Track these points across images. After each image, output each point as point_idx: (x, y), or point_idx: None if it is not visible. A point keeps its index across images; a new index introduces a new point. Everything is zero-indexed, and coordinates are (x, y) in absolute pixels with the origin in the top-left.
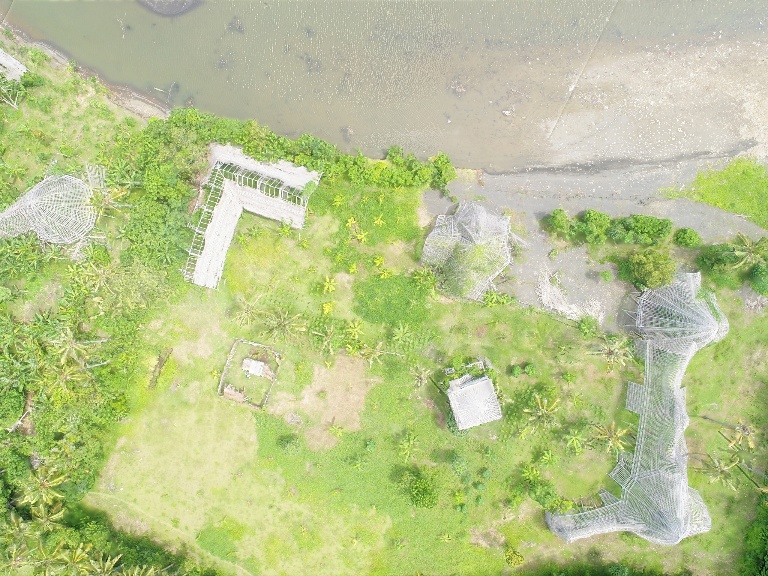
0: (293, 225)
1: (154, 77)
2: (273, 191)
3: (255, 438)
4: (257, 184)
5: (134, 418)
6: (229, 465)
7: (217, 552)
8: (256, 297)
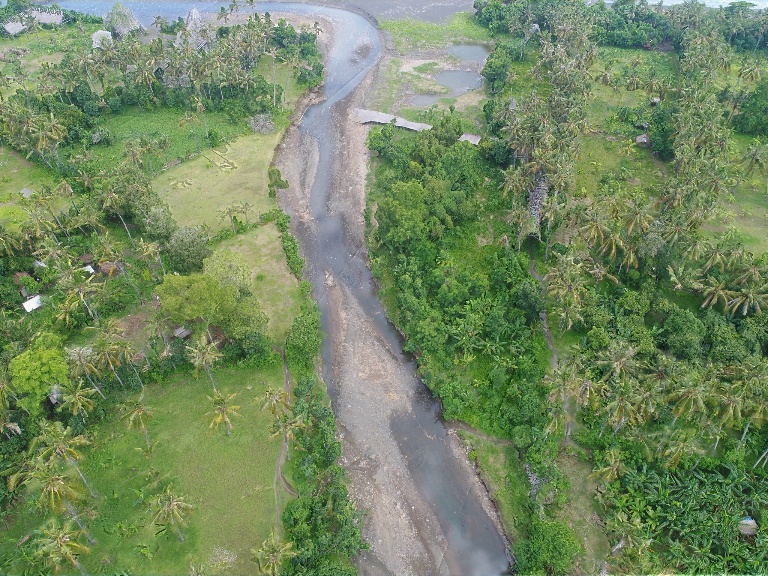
0: (56, 24)
1: None
2: (52, 12)
3: (1, 69)
4: (47, 11)
5: None
6: None
7: None
8: None
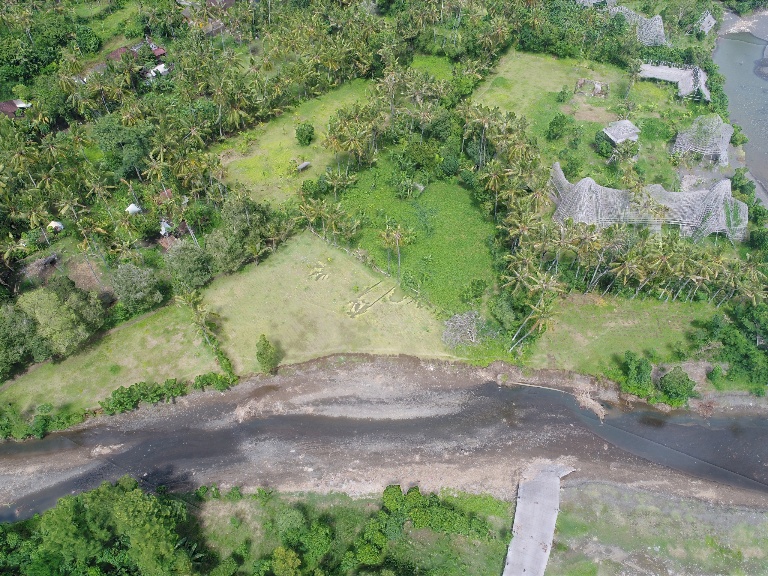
0: (679, 93)
1: (722, 71)
2: None
3: None
4: None
5: (555, 61)
6: (541, 85)
7: (495, 81)
8: (632, 91)
